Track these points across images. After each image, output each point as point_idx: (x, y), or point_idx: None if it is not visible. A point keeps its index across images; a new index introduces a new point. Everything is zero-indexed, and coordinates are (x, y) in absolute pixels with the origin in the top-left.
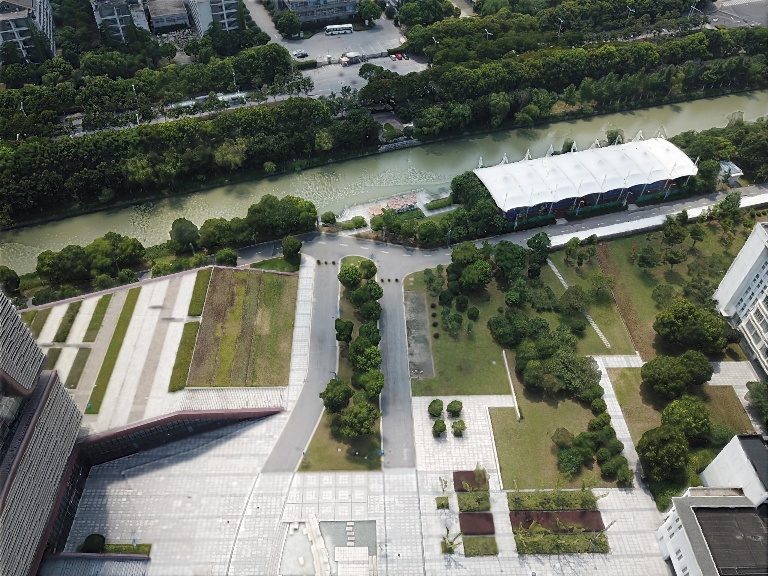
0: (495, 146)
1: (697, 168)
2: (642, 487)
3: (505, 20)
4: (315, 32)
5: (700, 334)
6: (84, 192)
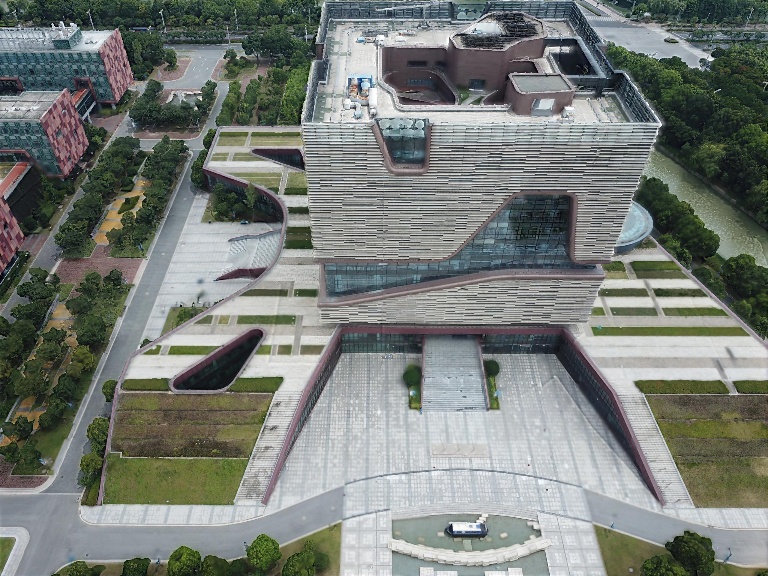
0: None
1: None
2: None
3: None
4: None
5: None
6: None
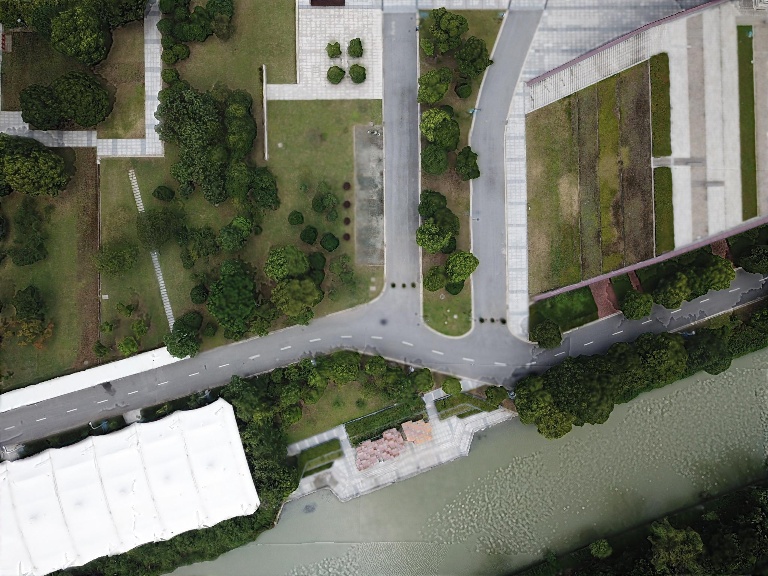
0: None
1: None
2: None
3: None
4: None
5: (15, 137)
6: None
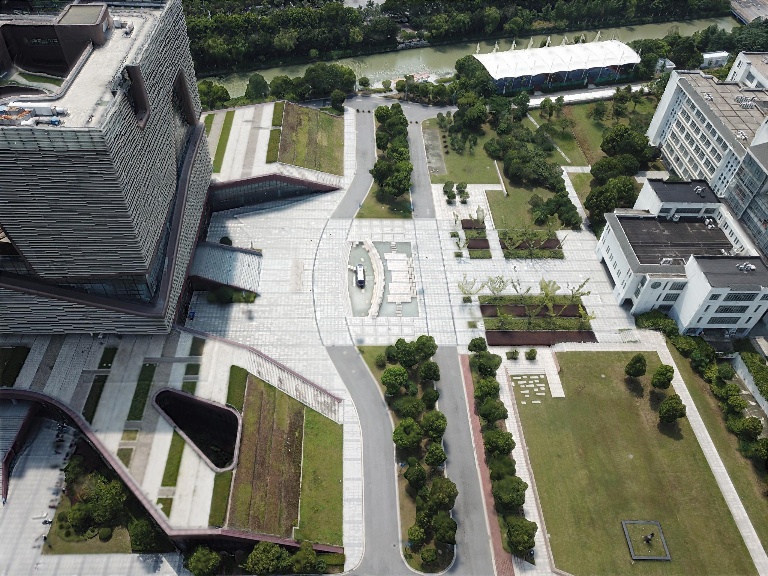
0: (488, 52)
1: (640, 58)
2: (588, 230)
3: None
4: None
5: (632, 145)
6: None
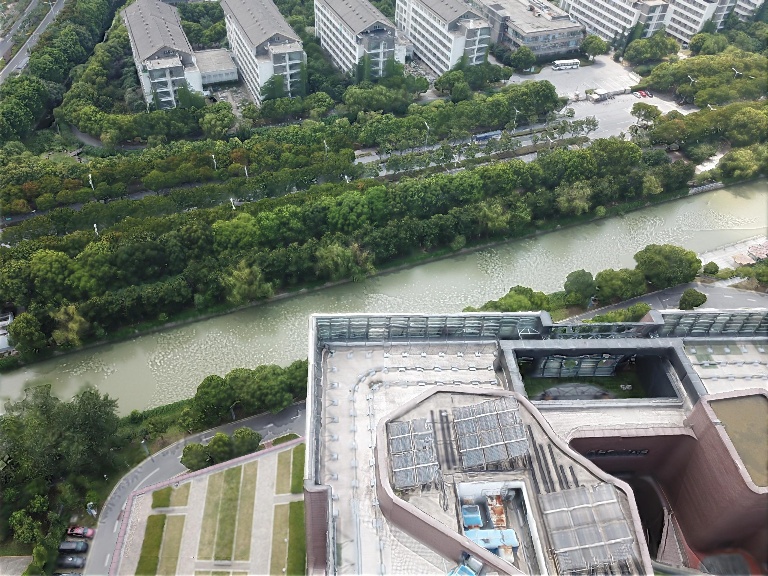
0: None
1: None
2: None
3: (742, 59)
4: (541, 67)
5: None
6: (437, 239)
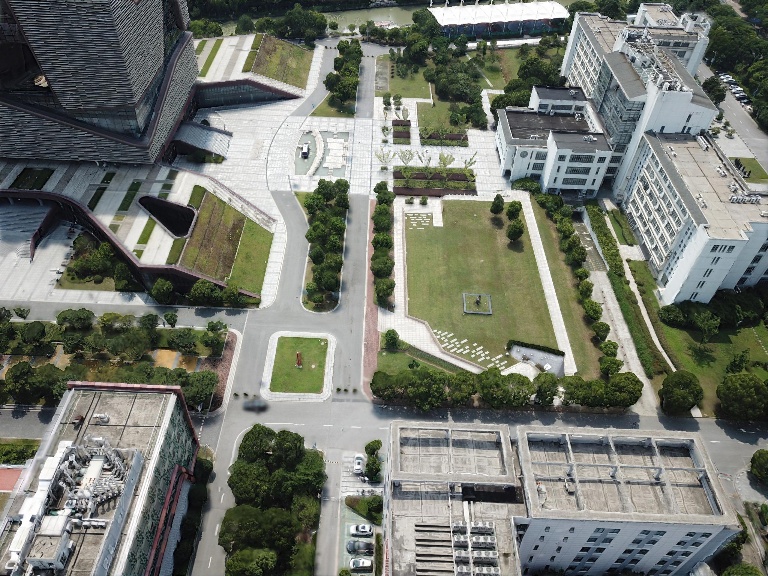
0: None
1: (569, 14)
2: (493, 130)
3: None
4: None
5: (539, 71)
6: None
